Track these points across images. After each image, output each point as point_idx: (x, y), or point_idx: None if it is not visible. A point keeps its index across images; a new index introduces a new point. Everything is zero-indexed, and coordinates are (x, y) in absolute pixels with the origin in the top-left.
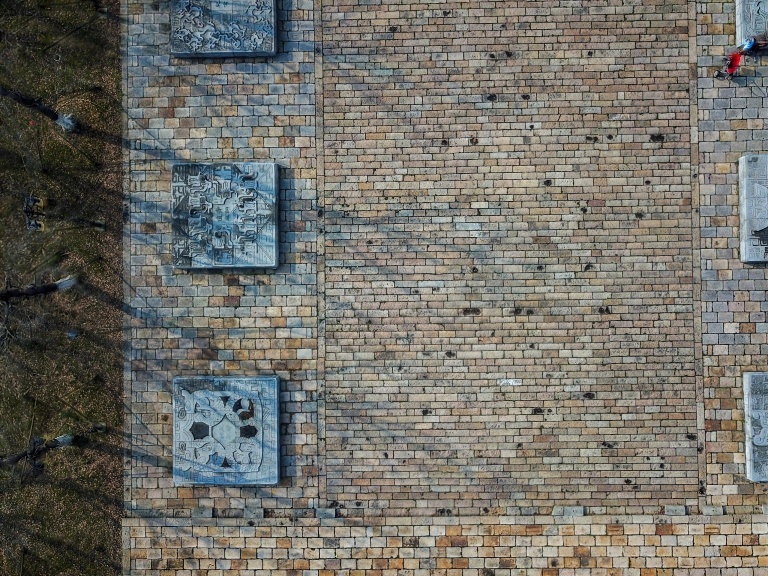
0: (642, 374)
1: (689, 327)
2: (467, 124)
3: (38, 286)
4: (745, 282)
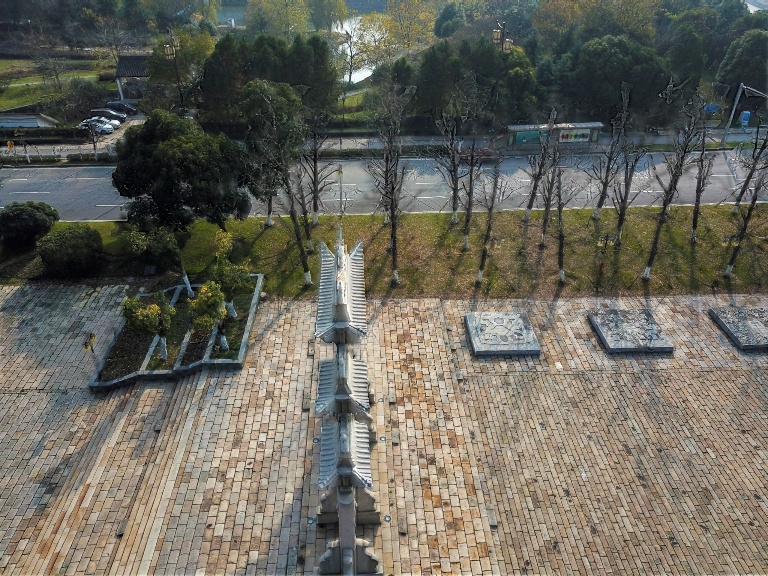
0: (630, 574)
1: None
2: (767, 444)
3: None
4: None
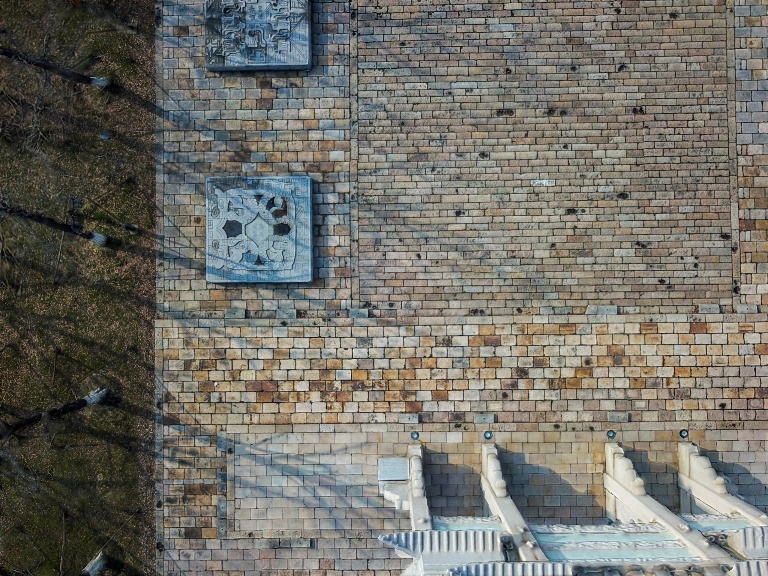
0: (676, 174)
1: (723, 127)
2: None
3: (73, 71)
4: None
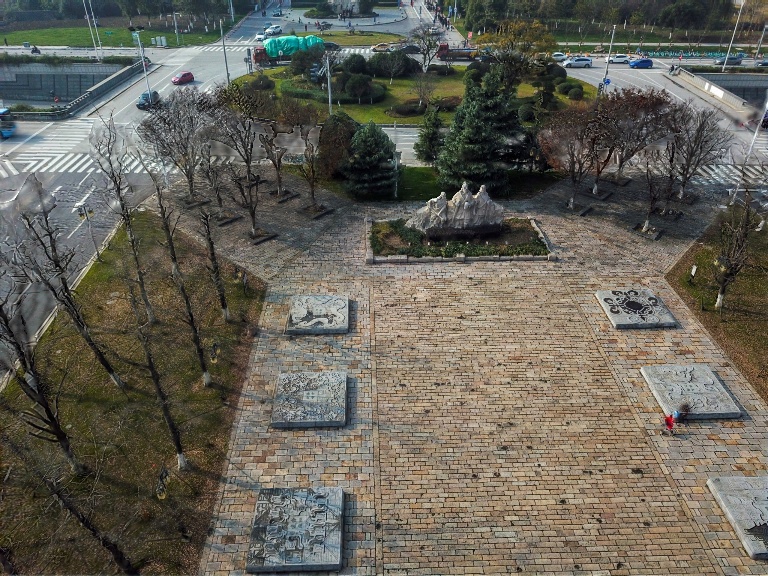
0: None
1: None
2: (490, 464)
3: (130, 564)
4: None
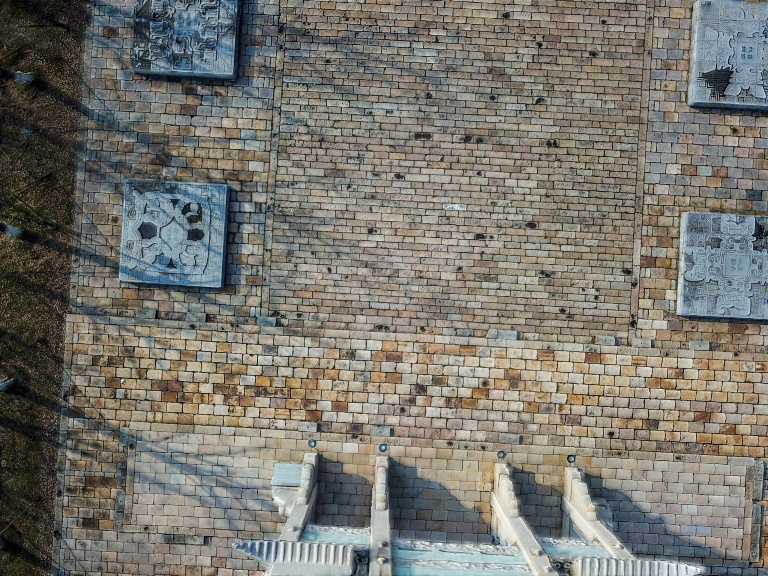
0: (584, 208)
1: (633, 165)
2: None
3: None
4: (690, 125)
